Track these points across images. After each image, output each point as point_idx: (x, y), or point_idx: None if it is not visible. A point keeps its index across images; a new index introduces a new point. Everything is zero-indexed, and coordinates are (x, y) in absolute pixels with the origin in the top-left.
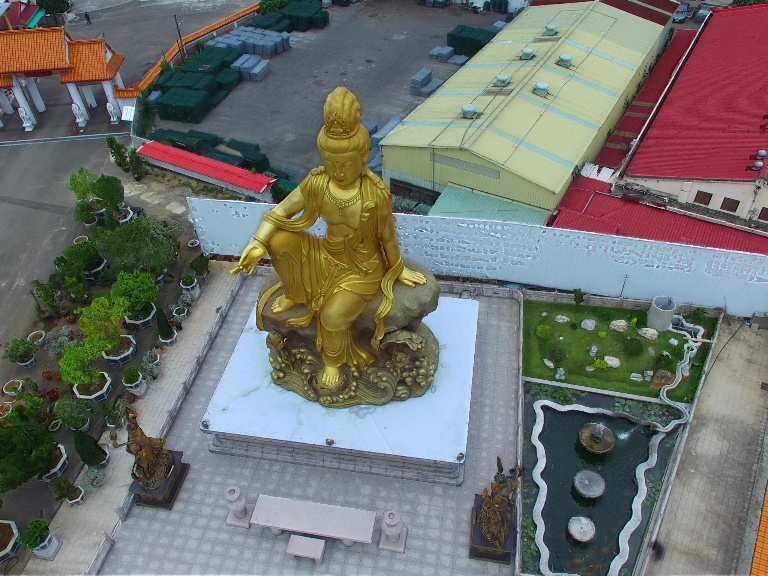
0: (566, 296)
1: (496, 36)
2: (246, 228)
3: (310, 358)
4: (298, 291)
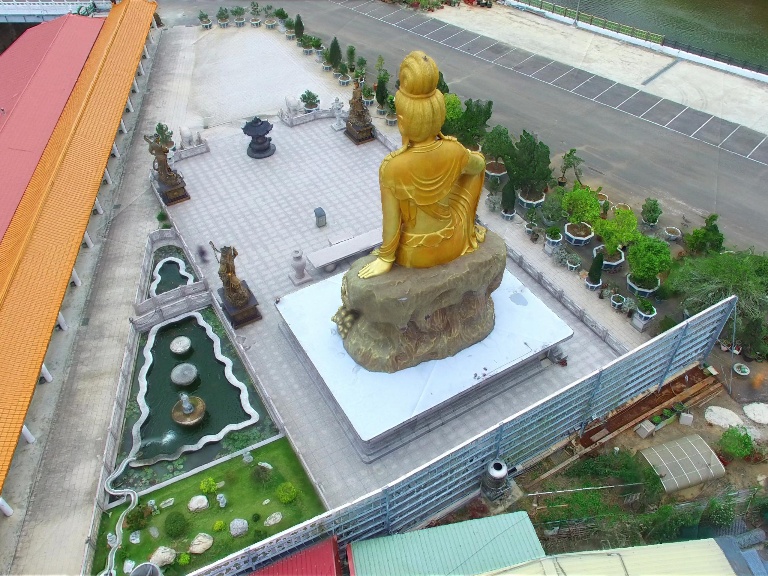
0: None
1: None
2: None
3: None
4: None
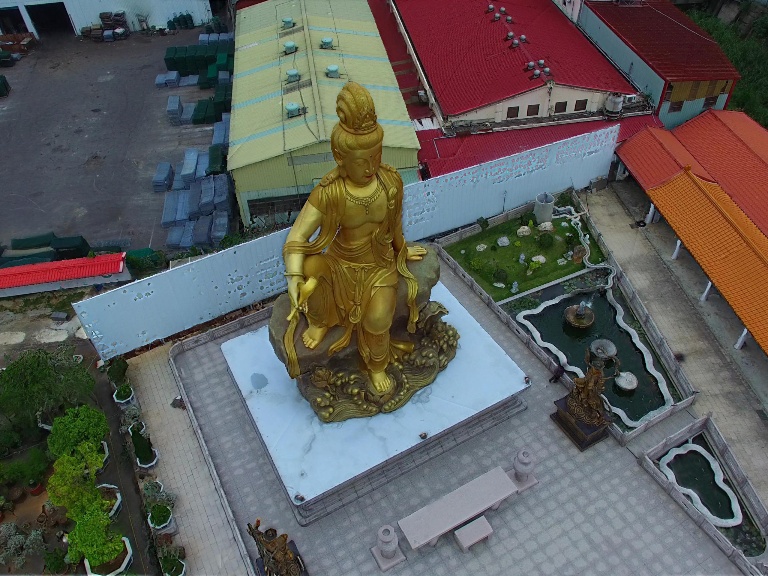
0: (468, 230)
1: (236, 43)
2: (154, 307)
3: (353, 377)
4: (331, 314)
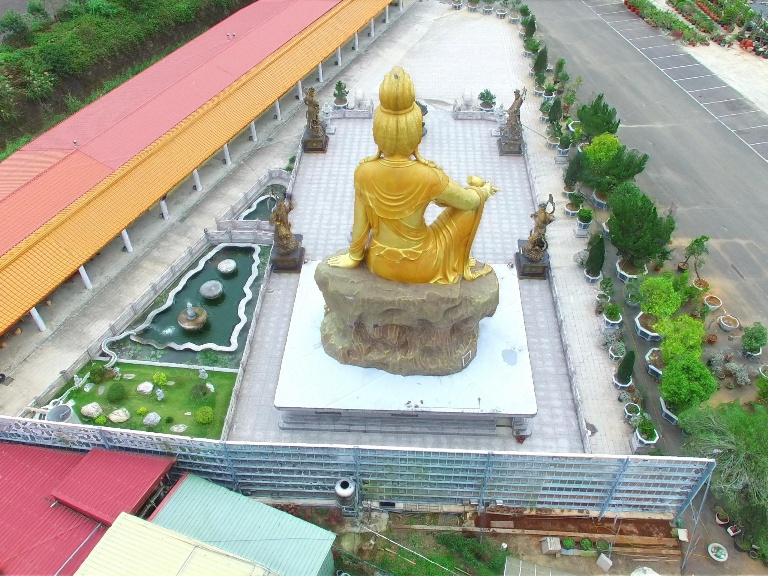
0: None
1: None
2: None
3: None
4: None
